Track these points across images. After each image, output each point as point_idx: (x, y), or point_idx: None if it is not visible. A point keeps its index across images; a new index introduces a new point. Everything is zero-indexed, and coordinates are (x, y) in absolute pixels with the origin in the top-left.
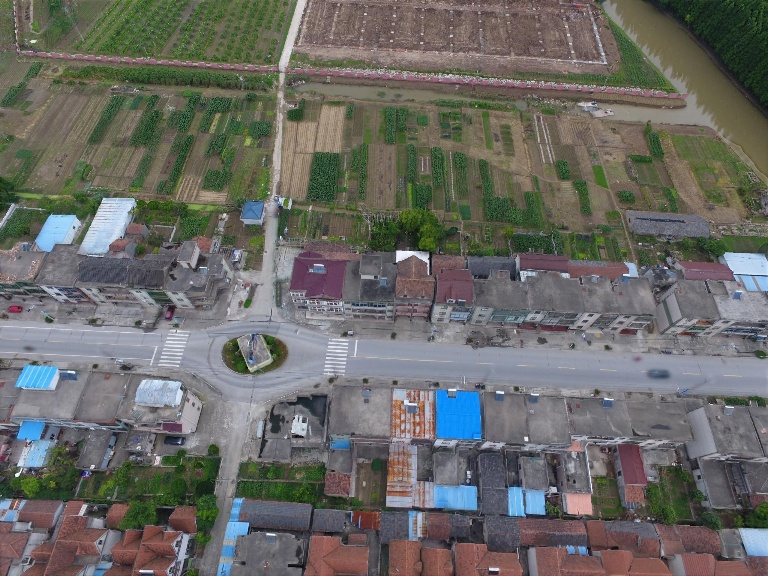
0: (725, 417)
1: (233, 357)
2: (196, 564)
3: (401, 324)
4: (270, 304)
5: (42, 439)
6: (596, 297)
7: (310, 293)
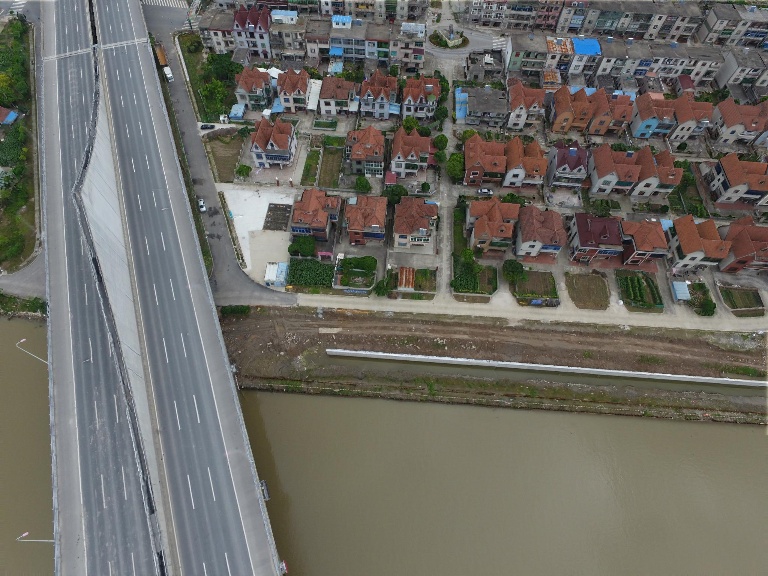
0: (743, 54)
1: None
2: None
3: (537, 33)
4: (452, 22)
5: (341, 59)
6: (664, 8)
7: None
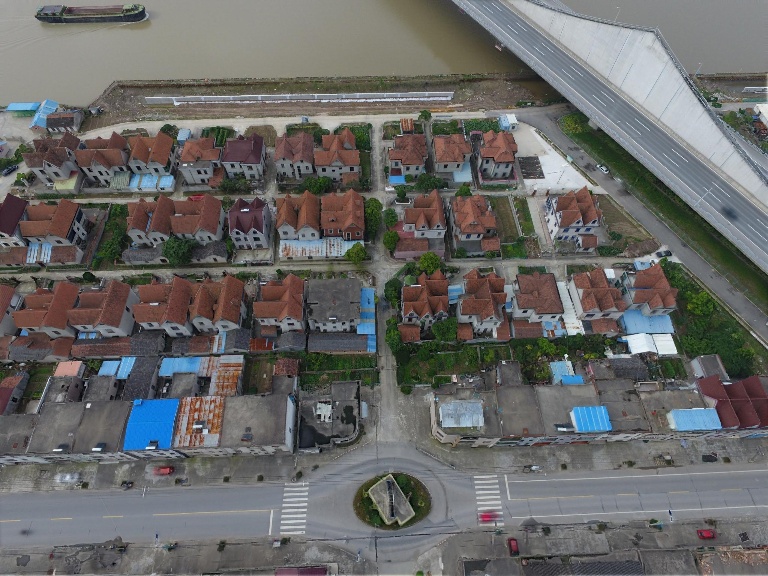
0: None
1: (415, 492)
2: (395, 311)
3: (210, 567)
4: None
5: None
6: None
7: (319, 574)
